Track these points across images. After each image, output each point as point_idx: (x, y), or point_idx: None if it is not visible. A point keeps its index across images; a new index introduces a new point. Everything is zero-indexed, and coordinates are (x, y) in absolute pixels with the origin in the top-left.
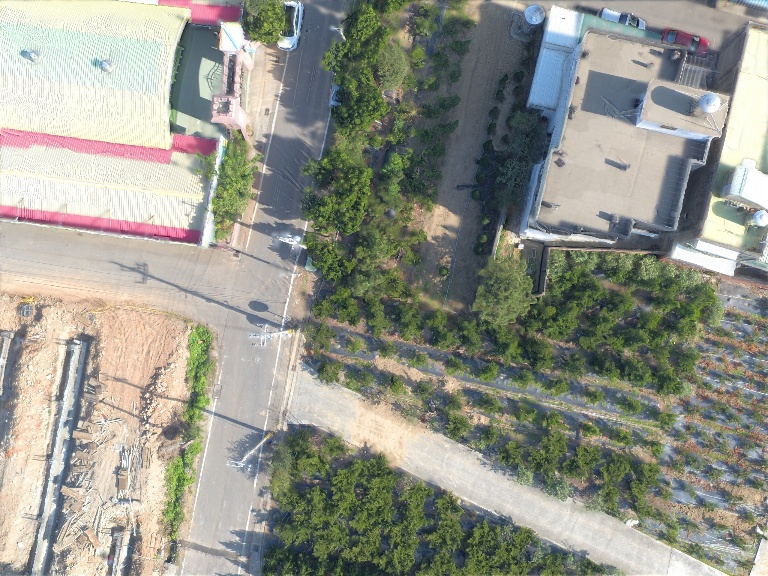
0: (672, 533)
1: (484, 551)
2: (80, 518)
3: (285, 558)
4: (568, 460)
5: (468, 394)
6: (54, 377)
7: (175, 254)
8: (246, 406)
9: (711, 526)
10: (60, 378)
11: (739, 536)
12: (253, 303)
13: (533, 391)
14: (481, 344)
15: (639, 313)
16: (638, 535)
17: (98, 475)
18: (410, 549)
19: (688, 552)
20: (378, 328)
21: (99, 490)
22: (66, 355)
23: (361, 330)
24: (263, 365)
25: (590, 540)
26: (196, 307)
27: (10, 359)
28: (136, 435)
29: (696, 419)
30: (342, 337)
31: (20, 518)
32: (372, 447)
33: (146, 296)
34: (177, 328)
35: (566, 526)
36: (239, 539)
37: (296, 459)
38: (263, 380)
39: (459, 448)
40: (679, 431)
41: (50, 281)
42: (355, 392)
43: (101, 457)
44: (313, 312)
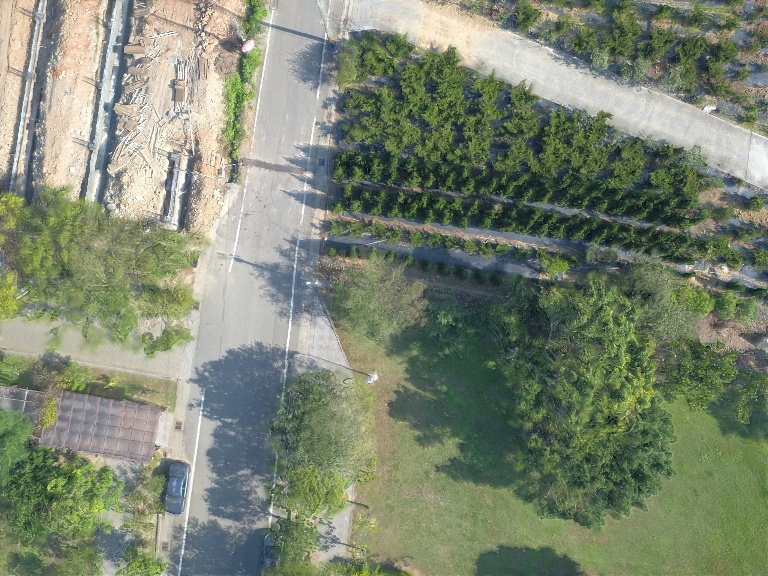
0: None
1: (561, 139)
2: (135, 138)
3: None
4: (642, 45)
5: None
6: None
7: None
8: (305, 15)
9: None
10: (106, 4)
11: None
12: None
13: None
14: None
15: None
16: (716, 121)
17: (153, 90)
18: (485, 142)
19: (767, 135)
20: None
21: (154, 105)
22: None
23: None
24: None
25: (668, 129)
26: None
27: None
28: (191, 47)
29: (767, 3)
30: None
31: (71, 142)
32: (438, 48)
33: None
34: None
35: (642, 116)
36: (304, 153)
37: (362, 54)
38: None
39: (528, 44)
40: (752, 12)
41: None
42: None
43: (155, 71)
44: None
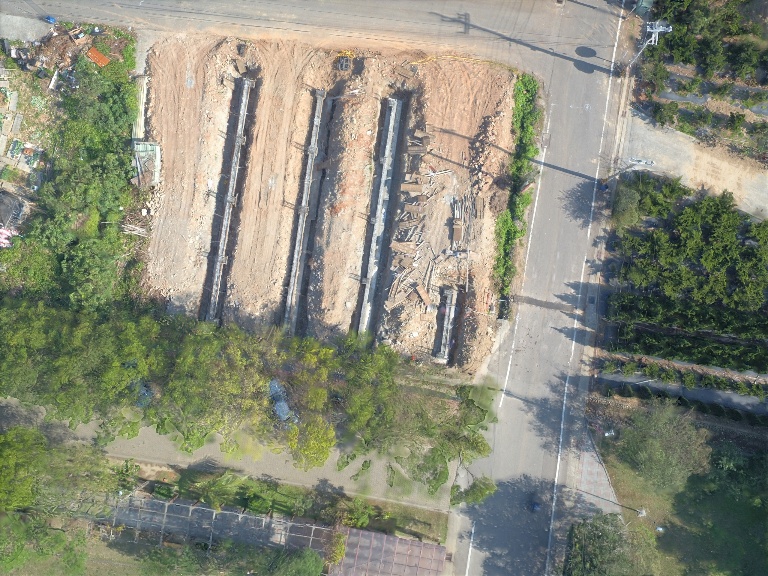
0: None
1: None
2: (410, 275)
3: (635, 299)
4: None
5: None
6: (374, 133)
7: (497, 2)
8: (577, 154)
9: None
10: None
11: None
12: (580, 49)
13: None
14: None
15: None
16: None
17: (429, 228)
18: (760, 287)
19: None
20: (716, 65)
21: (431, 243)
22: (380, 115)
23: (690, 74)
24: (593, 111)
25: None
26: (521, 55)
27: (322, 120)
28: (467, 185)
29: None
30: (672, 81)
31: (347, 277)
32: (710, 190)
33: (469, 46)
34: (502, 77)
35: None
36: (574, 291)
37: (641, 198)
38: (593, 127)
39: None
40: None
41: (367, 34)
42: (689, 135)
43: (432, 209)
44: (645, 53)
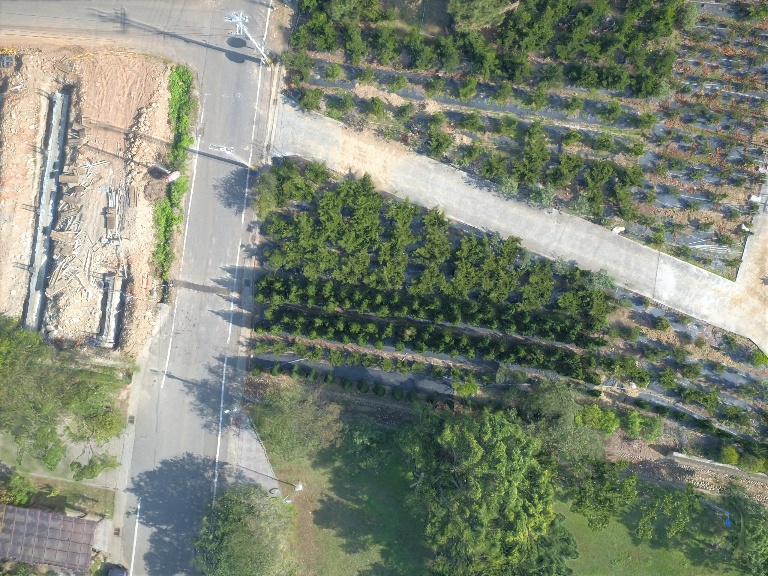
0: (659, 237)
1: (473, 263)
2: (71, 263)
3: (276, 281)
4: (551, 169)
5: (449, 115)
6: (38, 127)
7: None
8: (230, 142)
9: (697, 227)
10: (44, 132)
11: (725, 235)
12: (231, 39)
13: (513, 108)
14: (459, 65)
15: (614, 21)
16: (625, 241)
17: (86, 217)
18: (399, 266)
19: (675, 255)
20: (356, 51)
21: (88, 232)
22: (49, 109)
23: (340, 61)
24: (244, 100)
25: (578, 249)
26: (175, 48)
27: None
28: (122, 175)
29: (677, 124)
30: (321, 68)
31: (11, 266)
32: (357, 173)
33: (124, 40)
34: (157, 69)
35: (553, 237)
36: (230, 275)
37: (281, 183)
38: (245, 115)
39: (443, 168)
40: (660, 135)
41: (28, 32)
42: (337, 120)
43: (88, 199)
44: (291, 42)
